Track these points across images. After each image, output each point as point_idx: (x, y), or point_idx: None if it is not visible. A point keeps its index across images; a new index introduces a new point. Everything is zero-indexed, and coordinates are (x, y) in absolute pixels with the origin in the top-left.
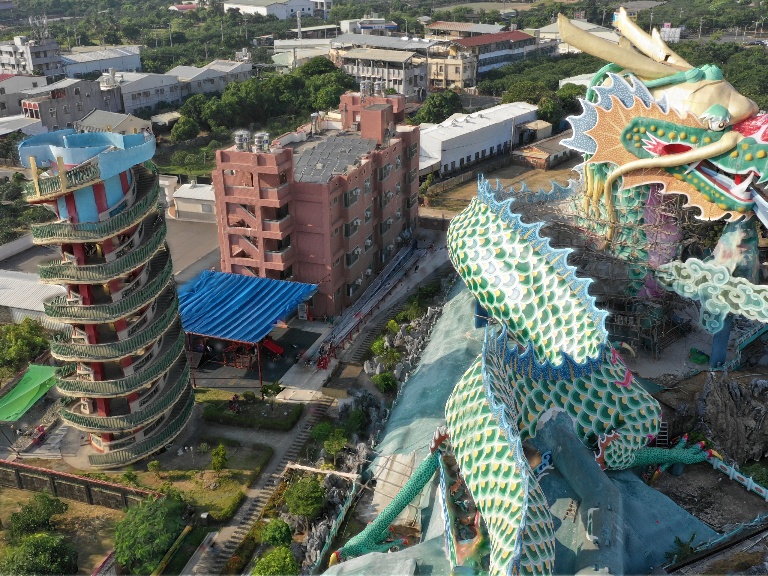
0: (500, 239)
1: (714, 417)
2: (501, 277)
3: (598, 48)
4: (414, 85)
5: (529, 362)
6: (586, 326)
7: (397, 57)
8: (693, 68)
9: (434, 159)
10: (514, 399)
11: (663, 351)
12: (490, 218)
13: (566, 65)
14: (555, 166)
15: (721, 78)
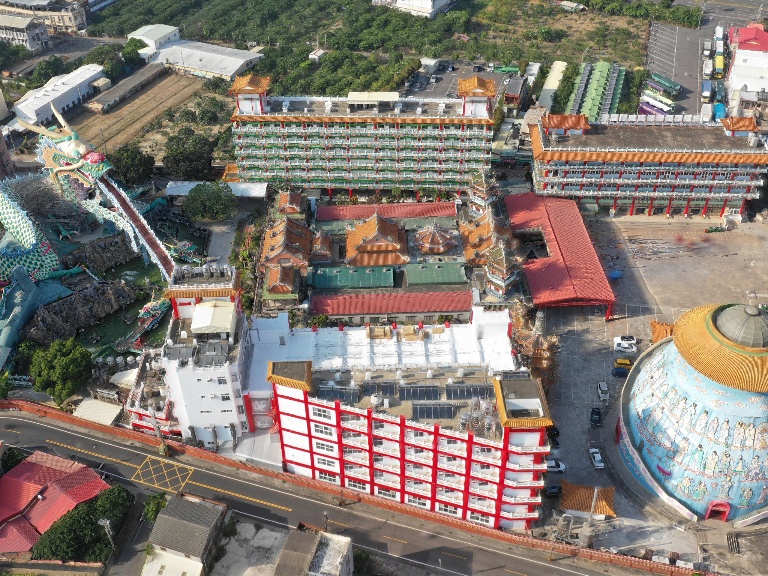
0: (7, 207)
1: (90, 256)
2: (9, 221)
3: (34, 129)
4: (38, 40)
5: (7, 254)
6: (33, 237)
7: (20, 24)
8: (70, 133)
9: (33, 120)
10: (0, 266)
11: (95, 230)
12: (3, 200)
13: (152, 1)
14: (109, 111)
15: (77, 139)
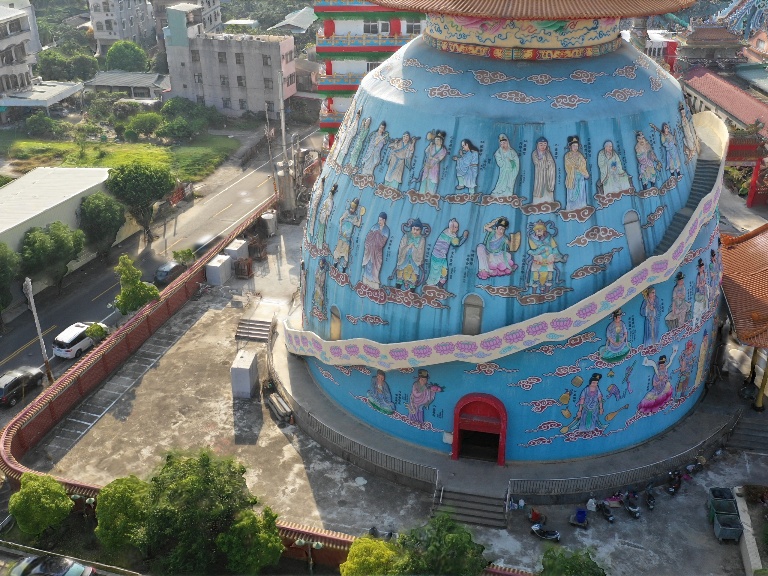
0: None
1: None
2: None
3: None
4: None
5: None
6: None
7: None
8: None
9: None
10: None
11: None
12: None
13: None
14: None
15: None
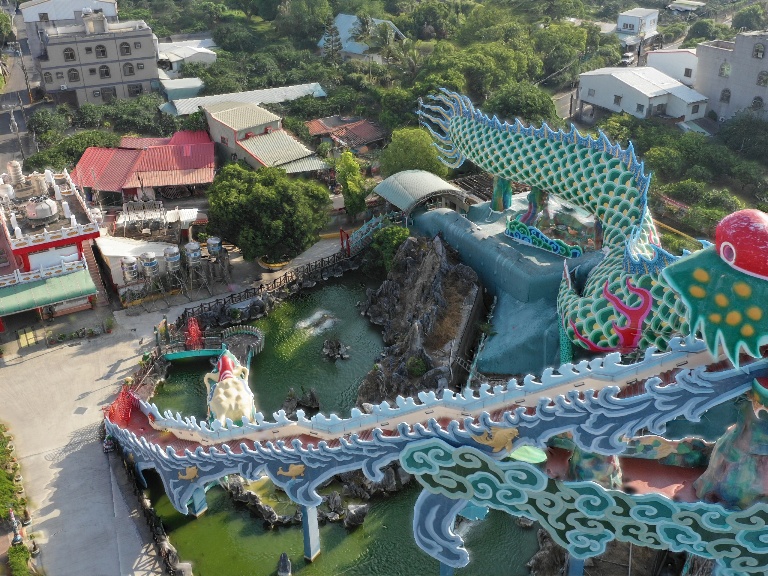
0: None
1: None
2: None
3: None
4: None
5: None
6: None
7: None
8: None
9: None
10: None
11: None
12: None
13: None
14: None
15: None
